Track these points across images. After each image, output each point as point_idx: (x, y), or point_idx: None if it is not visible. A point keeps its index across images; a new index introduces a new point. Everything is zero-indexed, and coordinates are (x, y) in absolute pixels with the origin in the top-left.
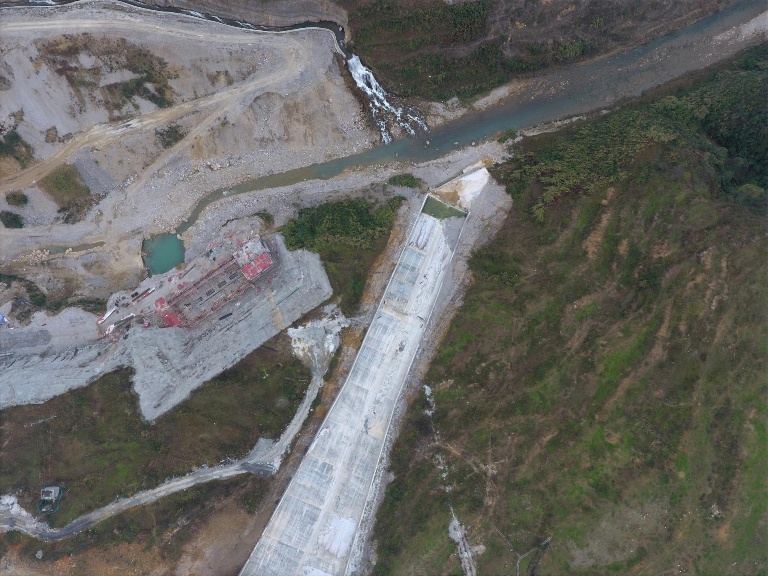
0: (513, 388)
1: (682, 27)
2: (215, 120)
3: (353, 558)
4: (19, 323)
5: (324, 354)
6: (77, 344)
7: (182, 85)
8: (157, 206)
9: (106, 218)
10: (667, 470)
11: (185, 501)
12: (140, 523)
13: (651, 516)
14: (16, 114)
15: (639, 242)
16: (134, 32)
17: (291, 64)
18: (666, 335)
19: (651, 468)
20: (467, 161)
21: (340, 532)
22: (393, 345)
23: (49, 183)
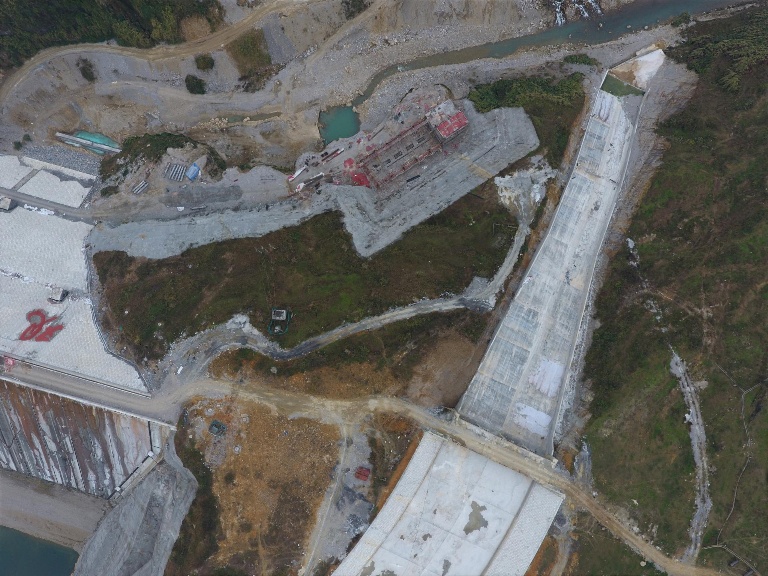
0: (721, 240)
1: None
2: None
3: (566, 396)
4: (211, 178)
5: (530, 203)
6: (267, 200)
7: None
8: (335, 78)
9: (285, 88)
10: None
11: (411, 327)
12: (369, 346)
13: None
14: None
15: None
16: None
17: None
18: None
19: None
20: (641, 43)
21: (549, 374)
22: (588, 204)
23: (236, 47)
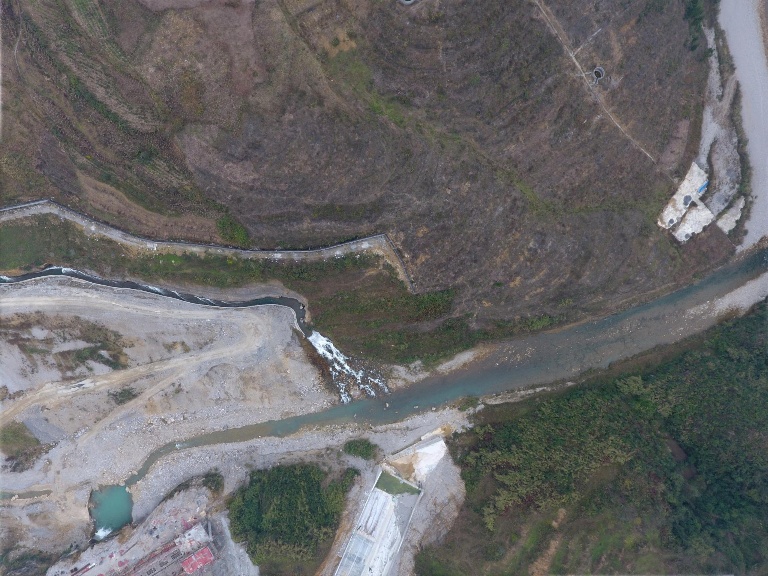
0: None
1: (655, 299)
2: (169, 386)
3: None
4: None
5: None
6: None
7: (137, 352)
8: (107, 458)
9: (55, 468)
10: None
11: None
12: None
13: None
14: None
15: None
16: (89, 309)
17: (249, 339)
18: None
19: None
20: (426, 429)
21: None
22: None
23: None
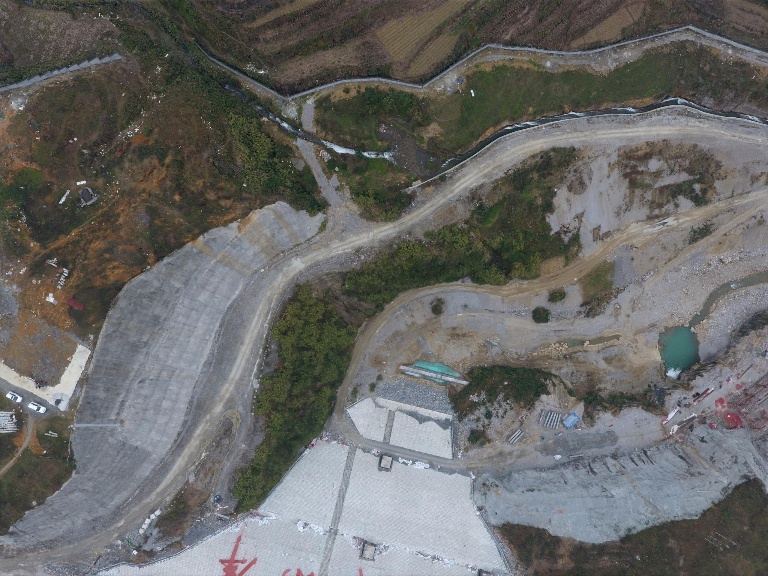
0: None
1: None
2: (750, 218)
3: None
4: (584, 424)
5: None
6: (643, 445)
7: (725, 185)
8: (673, 300)
9: (625, 312)
10: None
11: None
12: None
13: None
14: (578, 216)
15: None
16: (704, 138)
17: None
18: None
19: None
20: None
21: None
22: None
23: (588, 280)
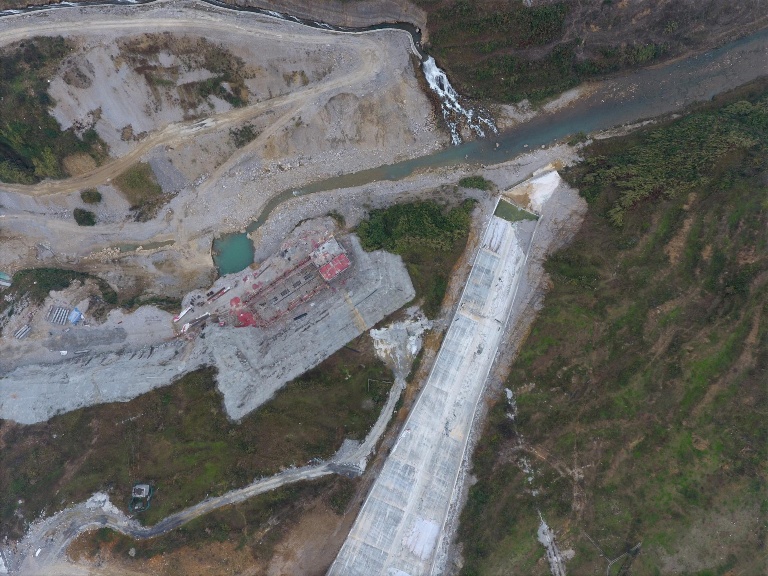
0: (597, 393)
1: (754, 32)
2: (289, 120)
3: (438, 560)
4: (95, 320)
5: (406, 356)
6: (152, 342)
7: (258, 85)
8: (228, 205)
9: (177, 217)
10: (758, 477)
11: (275, 501)
12: (231, 522)
13: (741, 523)
14: (94, 112)
15: (724, 248)
16: (214, 31)
17: (367, 65)
18: (755, 342)
19: (741, 475)
20: (537, 164)
21: (423, 534)
22: (471, 348)
23: (123, 181)
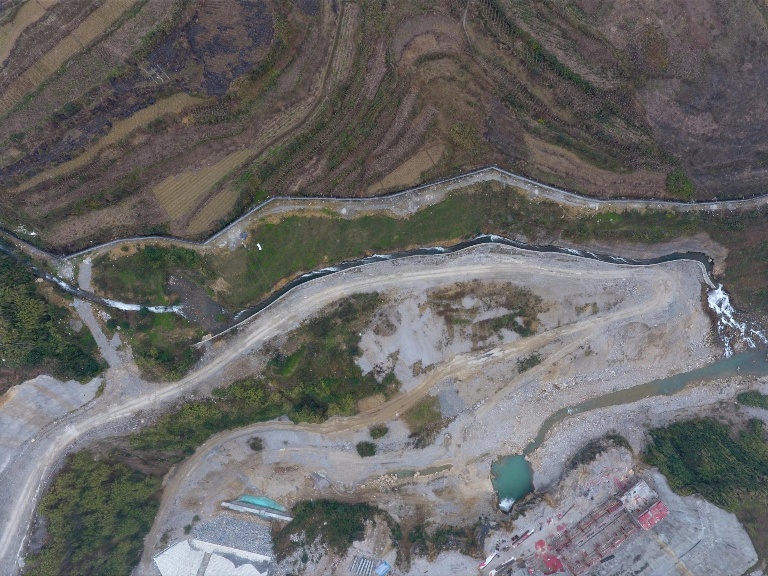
0: None
1: None
2: (578, 349)
3: None
4: (399, 570)
5: None
6: None
7: (549, 317)
8: (506, 428)
9: (455, 442)
10: None
11: None
12: None
13: None
14: (393, 354)
15: None
16: (519, 275)
17: (659, 295)
18: None
19: None
20: None
21: None
22: None
23: (411, 415)
